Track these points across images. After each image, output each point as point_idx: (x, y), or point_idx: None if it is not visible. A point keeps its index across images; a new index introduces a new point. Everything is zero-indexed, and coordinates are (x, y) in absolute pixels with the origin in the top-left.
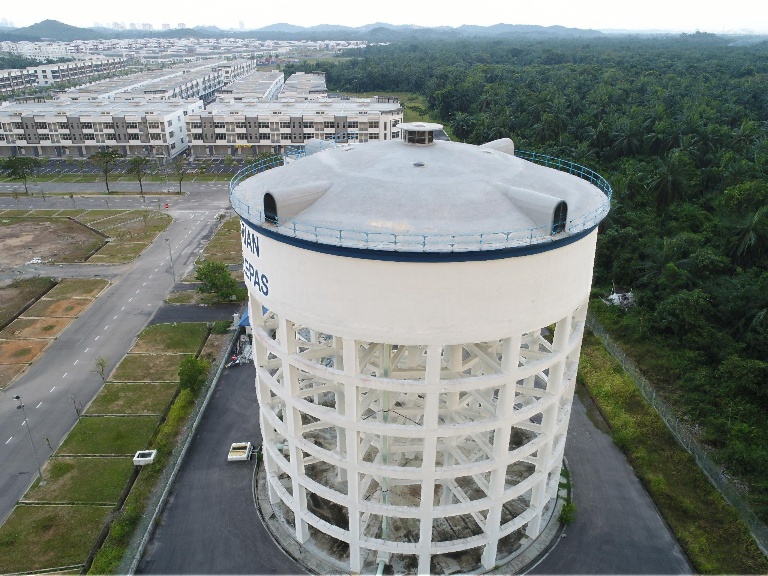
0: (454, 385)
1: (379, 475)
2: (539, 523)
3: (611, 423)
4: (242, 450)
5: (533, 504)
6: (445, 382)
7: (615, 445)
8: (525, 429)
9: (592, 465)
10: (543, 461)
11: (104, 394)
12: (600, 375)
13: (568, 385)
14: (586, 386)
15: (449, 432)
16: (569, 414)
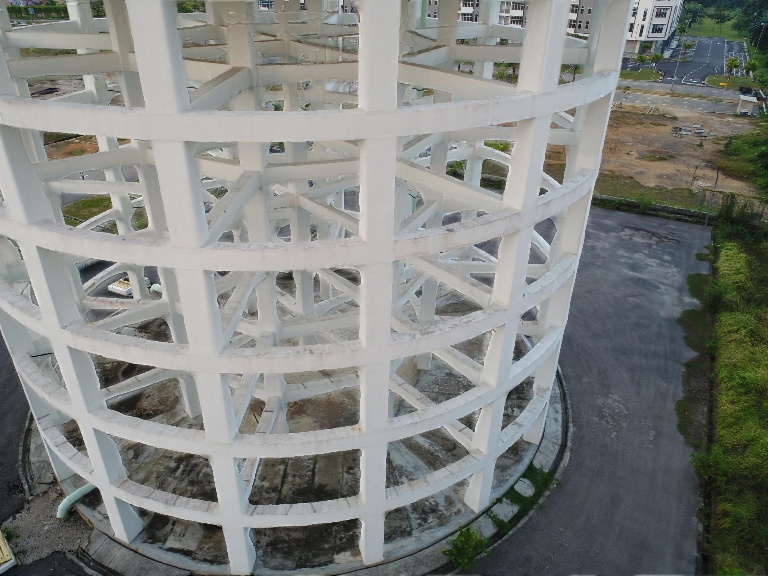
0: (15, 106)
1: (1, 306)
2: (379, 538)
3: (717, 433)
4: (129, 282)
5: (359, 494)
6: (4, 97)
7: (695, 473)
8: (529, 384)
9: (613, 488)
10: (363, 408)
11: (91, 199)
12: (759, 353)
13: (437, 241)
14: (715, 361)
15: (52, 239)
16: (501, 341)
